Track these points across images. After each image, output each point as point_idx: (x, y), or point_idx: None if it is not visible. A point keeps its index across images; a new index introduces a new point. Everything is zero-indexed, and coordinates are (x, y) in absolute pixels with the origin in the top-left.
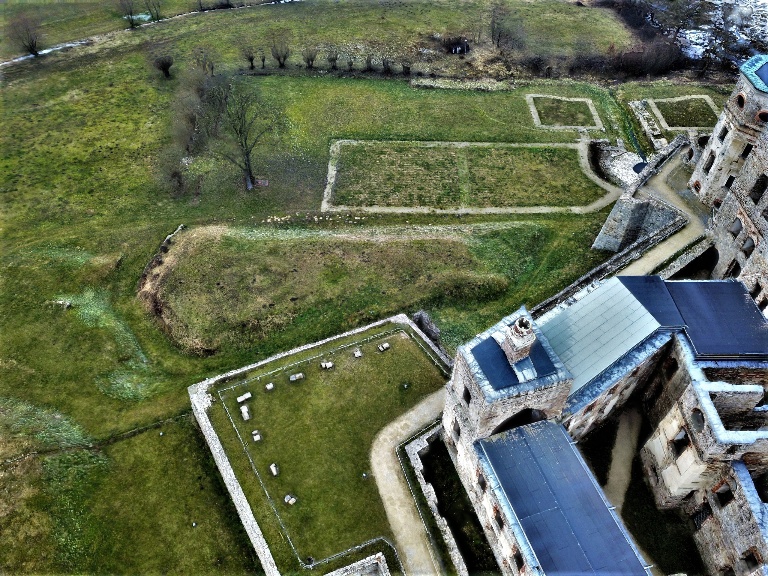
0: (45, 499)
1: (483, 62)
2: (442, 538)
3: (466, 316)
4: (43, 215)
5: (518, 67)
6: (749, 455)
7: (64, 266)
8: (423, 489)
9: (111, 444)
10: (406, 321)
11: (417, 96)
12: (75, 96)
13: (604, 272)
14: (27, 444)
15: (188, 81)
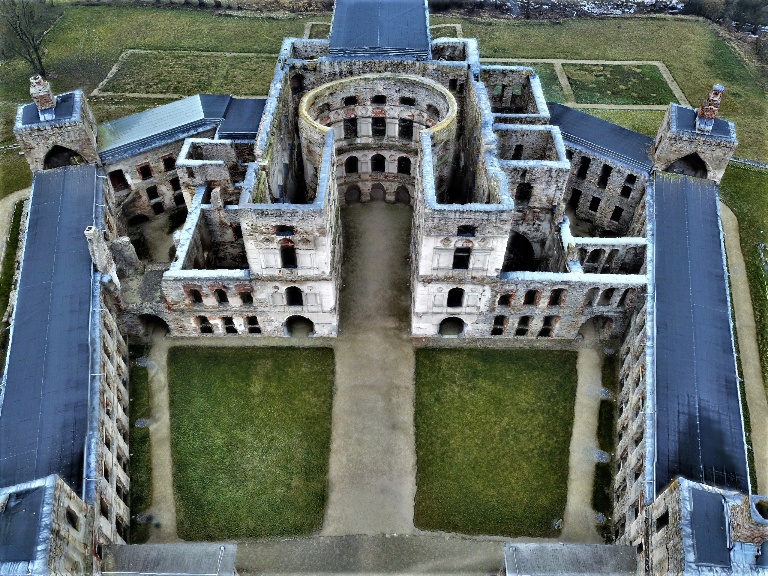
0: None
1: (290, 0)
2: (17, 243)
3: None
4: None
5: (318, 4)
6: (214, 183)
7: None
8: (21, 221)
9: None
10: None
11: (214, 21)
12: None
13: None
14: None
15: (18, 4)
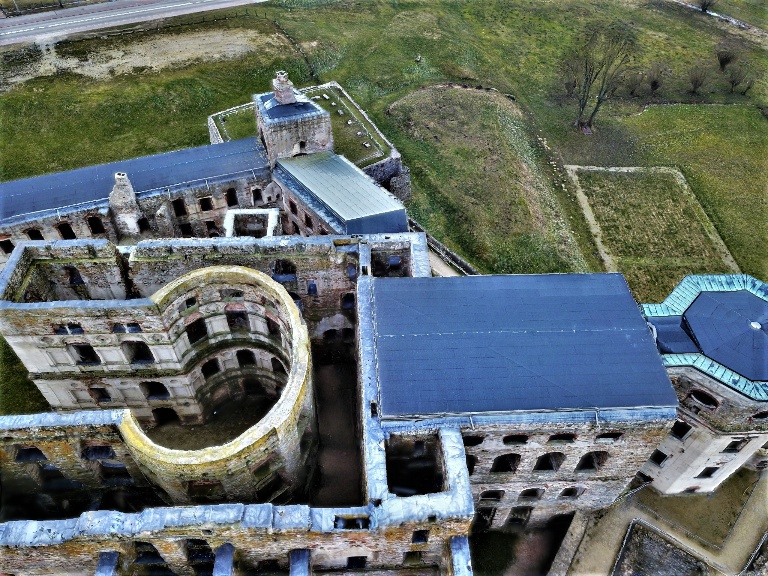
0: (279, 62)
1: None
2: None
3: (440, 229)
4: (509, 49)
5: None
6: None
7: (454, 57)
8: None
9: (315, 81)
10: (393, 156)
11: None
12: (657, 36)
13: (469, 273)
14: (310, 53)
15: None
